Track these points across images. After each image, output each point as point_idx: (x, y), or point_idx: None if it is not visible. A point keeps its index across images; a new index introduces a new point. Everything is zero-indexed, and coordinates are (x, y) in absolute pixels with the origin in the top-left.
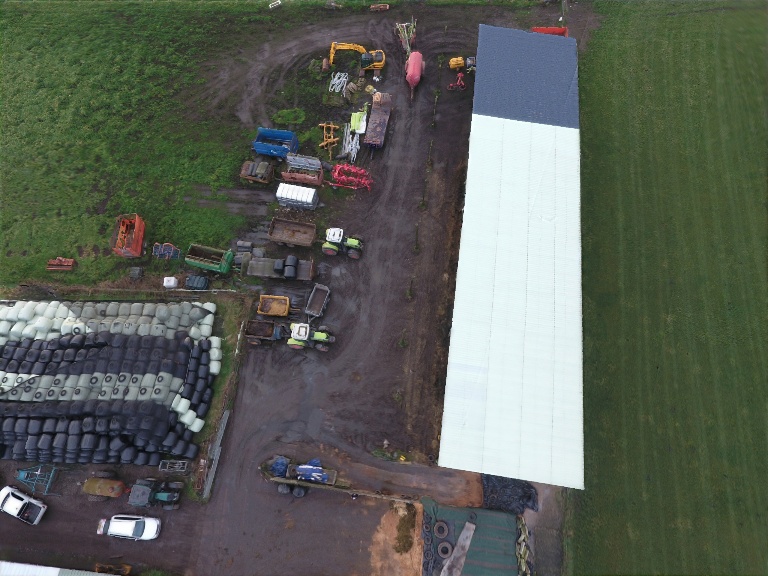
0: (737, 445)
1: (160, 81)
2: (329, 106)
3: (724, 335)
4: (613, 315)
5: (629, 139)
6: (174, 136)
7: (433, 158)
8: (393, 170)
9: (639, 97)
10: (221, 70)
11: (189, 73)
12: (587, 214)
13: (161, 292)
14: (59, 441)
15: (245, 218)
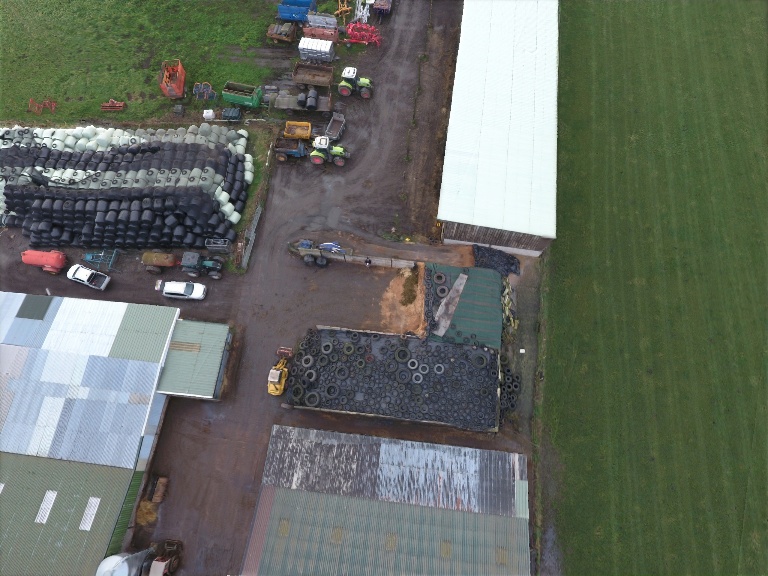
0: (686, 226)
1: None
2: None
3: (678, 149)
4: (585, 136)
5: (603, 6)
6: (208, 9)
7: (433, 23)
8: (399, 32)
9: None
10: None
11: None
12: (565, 63)
13: (200, 124)
14: (123, 215)
15: (271, 69)
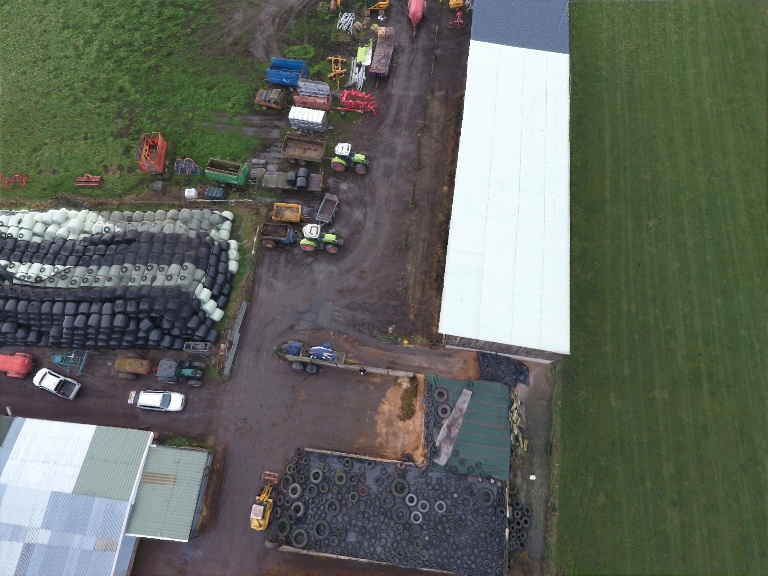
0: (711, 329)
1: (178, 22)
2: (337, 42)
3: (701, 236)
4: (599, 220)
5: (616, 69)
6: (192, 69)
7: (434, 87)
8: (397, 98)
9: (626, 33)
10: (235, 12)
11: (205, 14)
12: (576, 134)
13: (182, 204)
14: (93, 320)
15: (259, 140)
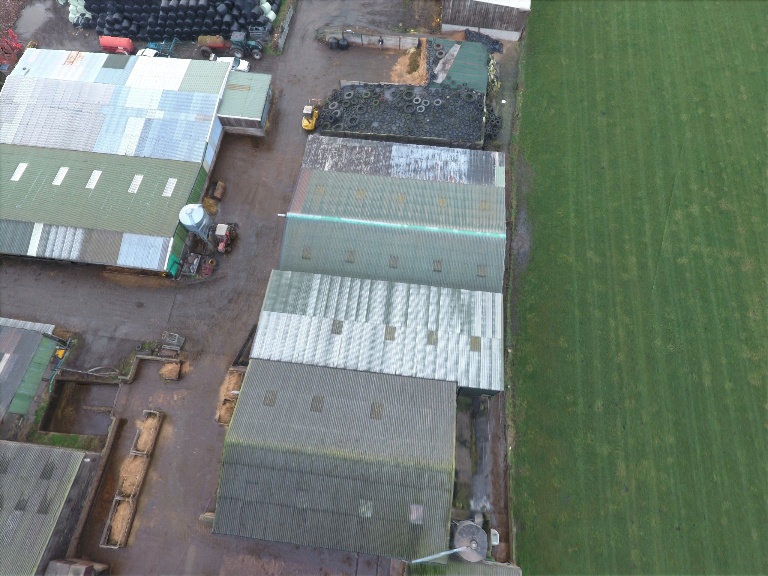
0: (637, 20)
1: None
2: None
3: None
4: None
5: None
6: None
7: None
8: None
9: None
10: None
11: None
12: None
13: None
14: (184, 1)
15: None
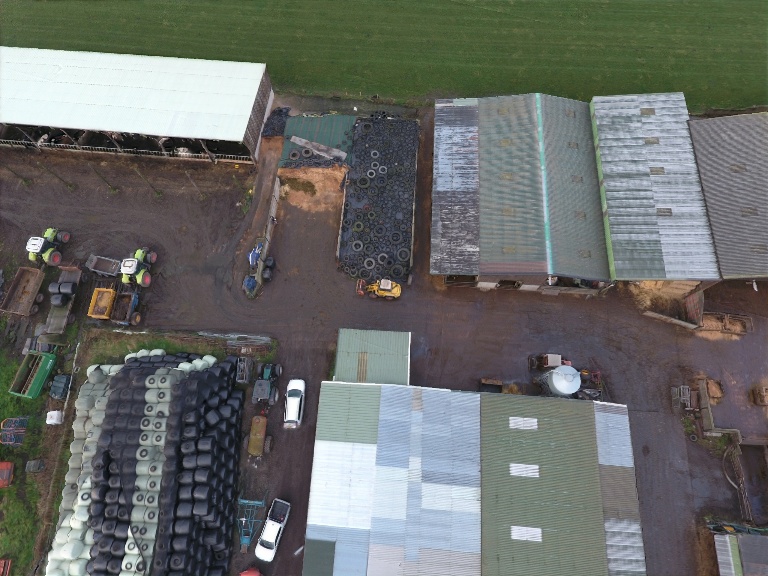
0: (254, 2)
1: None
2: None
3: None
4: (158, 55)
5: (5, 29)
6: None
7: None
8: None
9: None
10: None
11: None
12: None
13: (65, 431)
14: (202, 474)
15: None
